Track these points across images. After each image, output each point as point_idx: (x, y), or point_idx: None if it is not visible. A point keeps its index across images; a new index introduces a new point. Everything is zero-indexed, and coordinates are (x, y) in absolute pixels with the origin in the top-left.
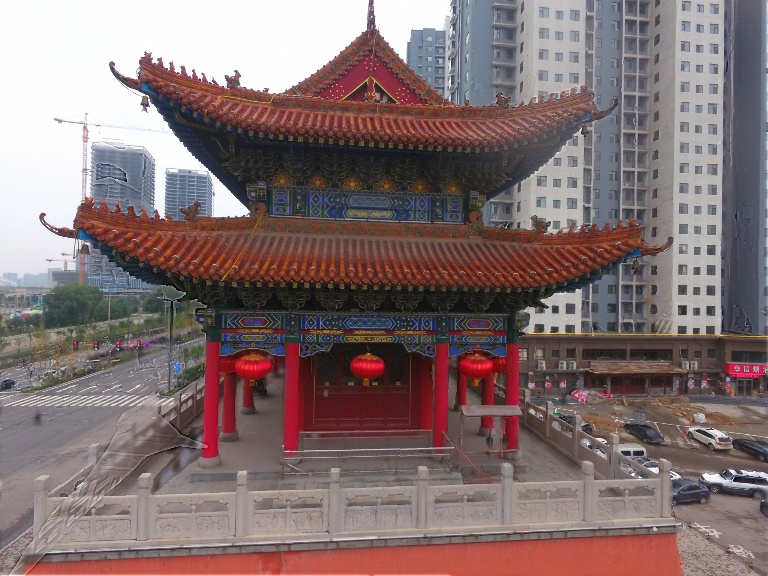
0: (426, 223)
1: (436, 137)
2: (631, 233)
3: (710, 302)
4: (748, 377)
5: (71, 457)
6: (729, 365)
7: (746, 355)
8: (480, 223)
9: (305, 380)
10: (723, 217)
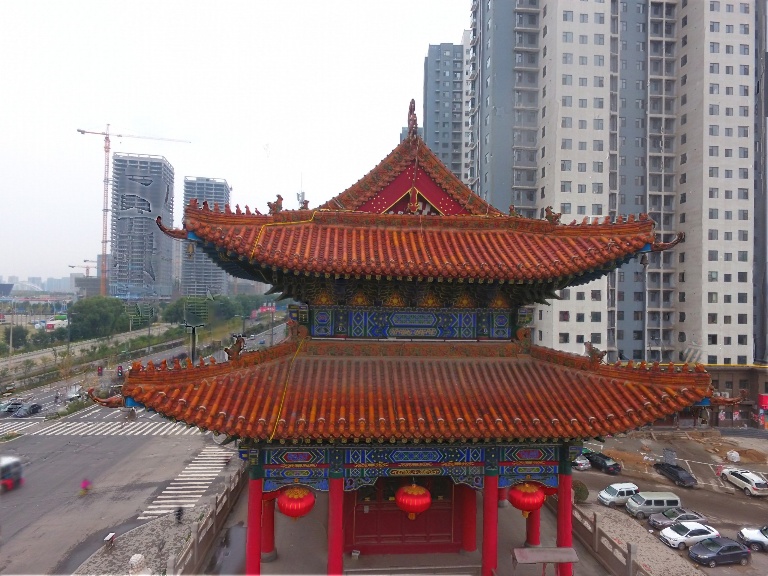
0: (472, 341)
1: (487, 271)
2: (698, 380)
3: (742, 331)
4: None
5: (98, 498)
6: (762, 397)
7: None
8: (528, 340)
9: (349, 513)
10: (755, 243)
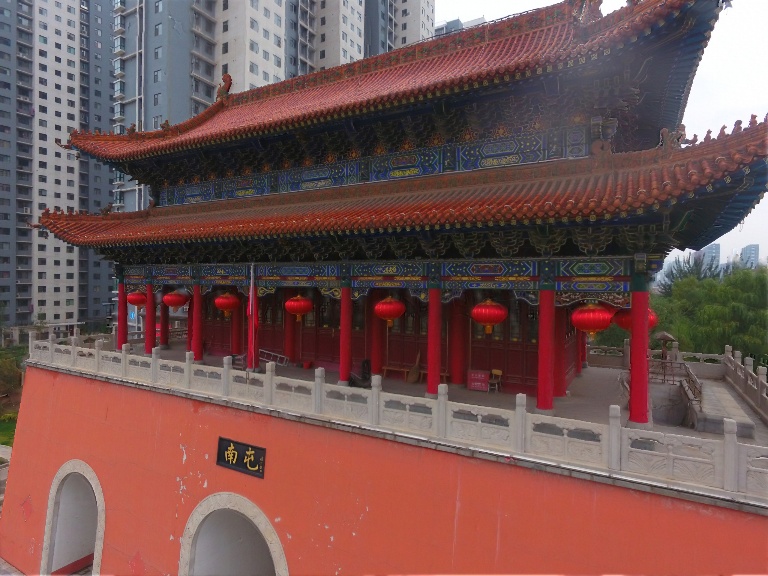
0: None
1: None
2: None
3: None
4: None
5: None
6: None
7: None
8: None
9: None
10: None
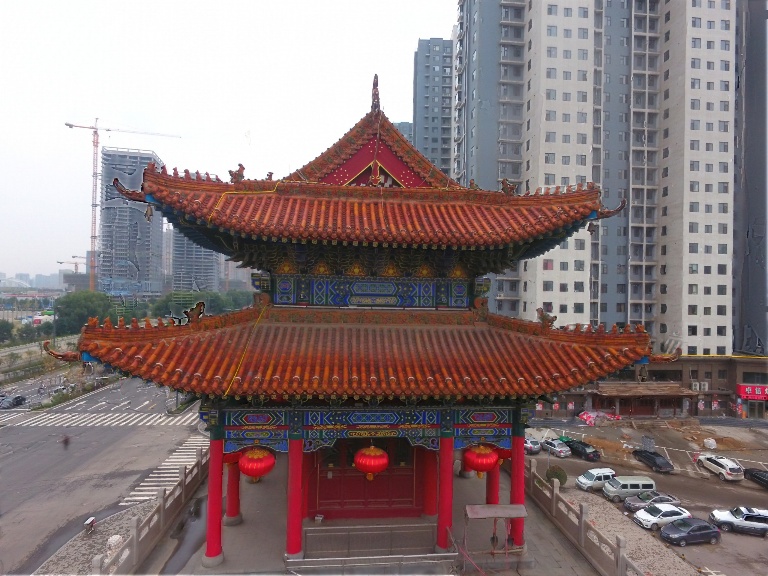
0: (431, 310)
1: (440, 237)
2: (638, 339)
3: (721, 322)
4: (760, 399)
5: (80, 485)
6: (740, 387)
7: (758, 376)
8: (485, 309)
9: (308, 474)
10: (734, 236)
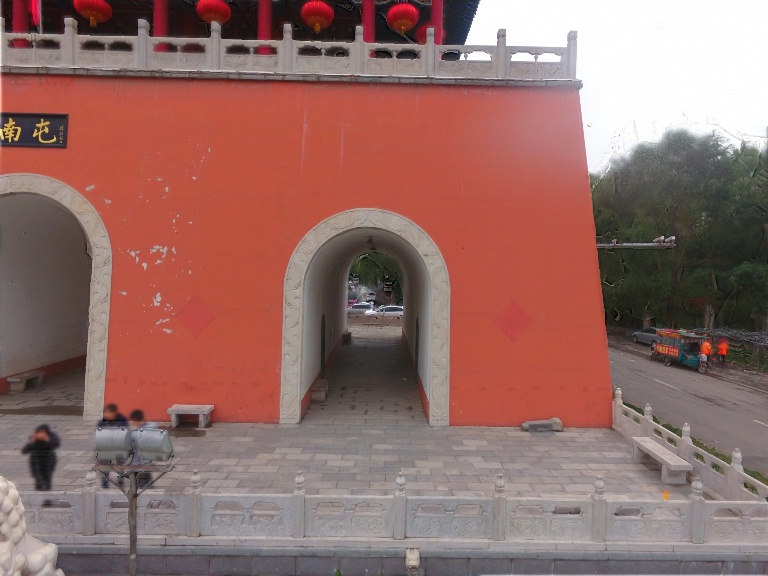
0: None
1: None
2: None
3: None
4: None
5: None
6: None
7: None
8: None
9: None
10: None
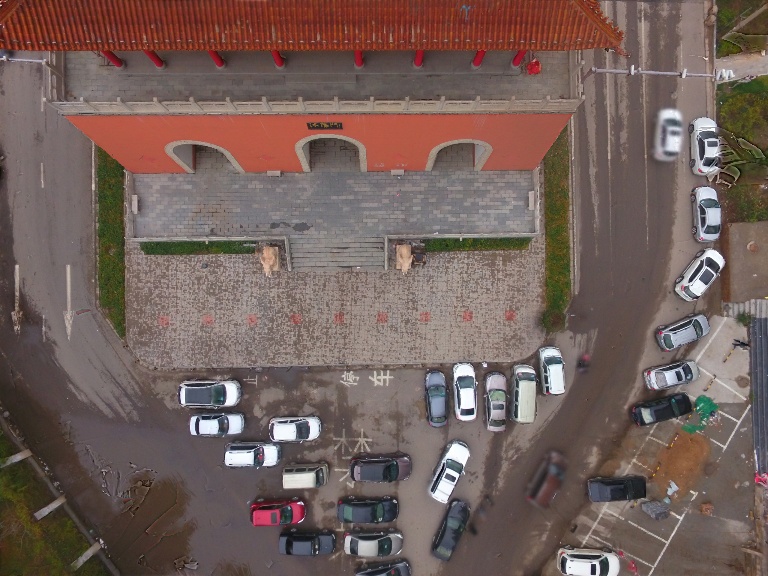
0: None
1: None
2: None
3: None
4: None
5: None
6: None
7: None
8: None
9: None
10: None
